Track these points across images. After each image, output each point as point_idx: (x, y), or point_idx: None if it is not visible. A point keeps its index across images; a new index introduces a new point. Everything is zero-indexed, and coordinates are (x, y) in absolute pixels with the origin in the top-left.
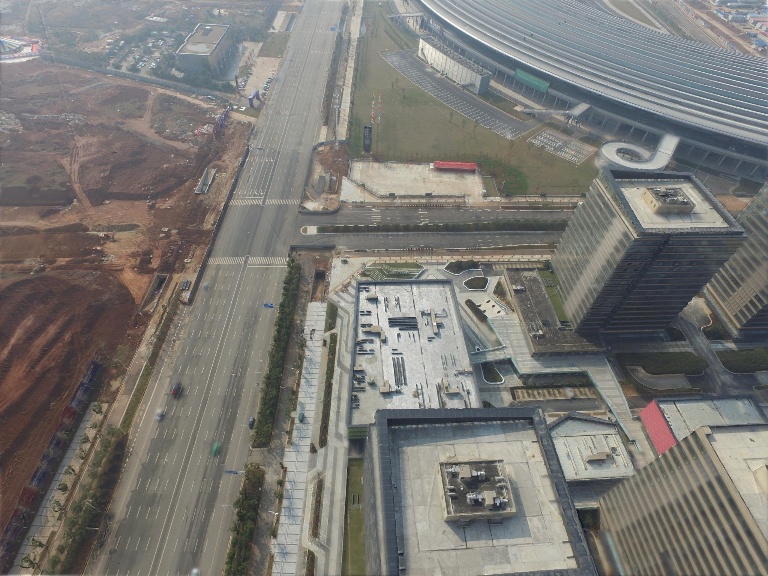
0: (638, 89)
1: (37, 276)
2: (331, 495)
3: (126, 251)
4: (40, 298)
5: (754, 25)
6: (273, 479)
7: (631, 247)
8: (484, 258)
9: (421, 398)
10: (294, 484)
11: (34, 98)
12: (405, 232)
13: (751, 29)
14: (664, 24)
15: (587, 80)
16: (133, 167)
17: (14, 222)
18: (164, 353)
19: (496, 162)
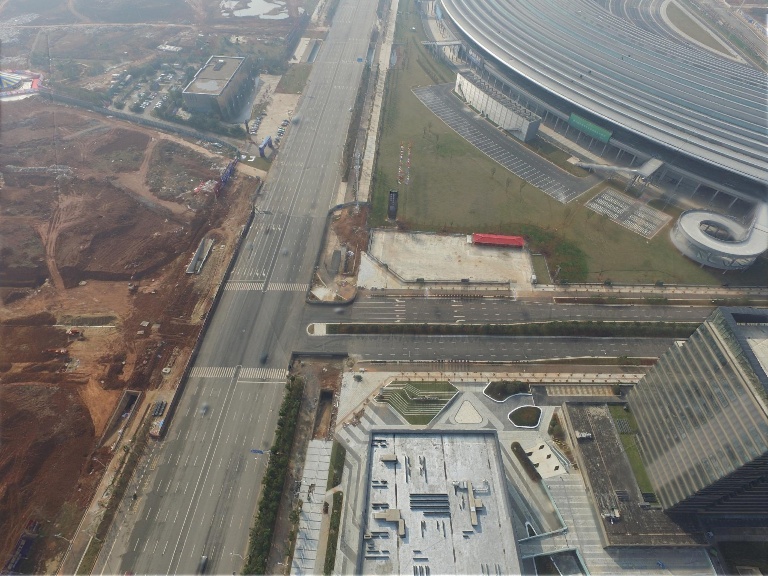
0: (725, 145)
1: None
2: None
3: (95, 354)
4: None
5: None
6: None
7: None
8: (535, 377)
9: None
10: None
11: (22, 146)
12: (435, 335)
13: None
14: (739, 51)
15: (660, 131)
16: (119, 236)
17: None
18: (120, 516)
19: (548, 234)
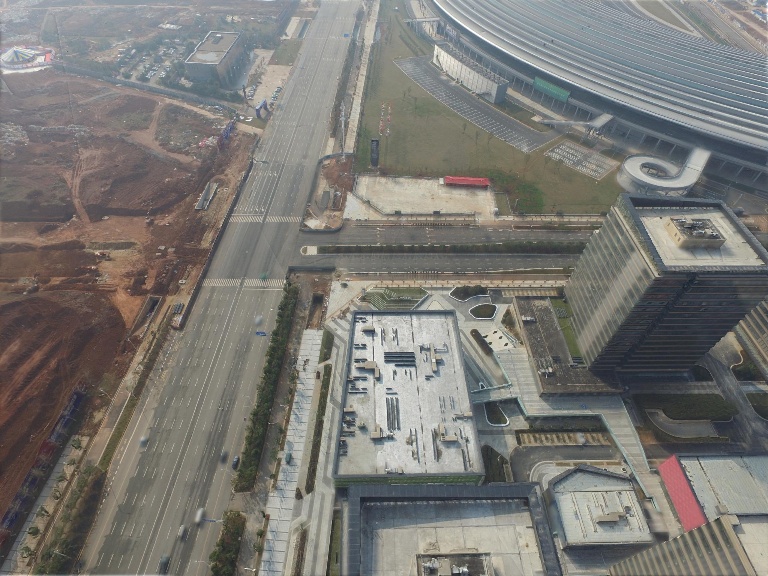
0: (666, 99)
1: (27, 298)
2: (315, 548)
3: (121, 271)
4: (28, 322)
5: None
6: (254, 528)
7: (651, 286)
8: (493, 283)
9: (415, 445)
10: (276, 534)
11: (42, 109)
12: (410, 253)
13: None
14: (696, 26)
15: (610, 89)
16: (135, 181)
17: (12, 238)
18: (151, 382)
19: (510, 177)
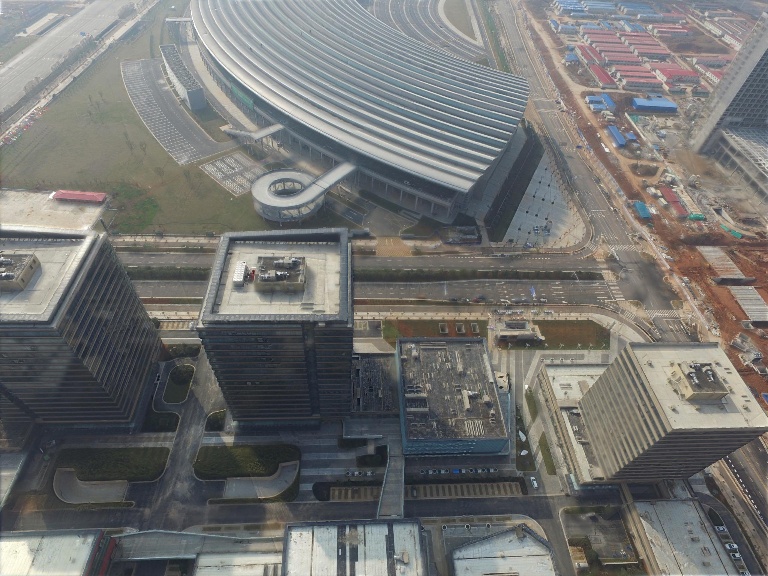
0: (327, 110)
1: None
2: None
3: None
4: None
5: (582, 37)
6: None
7: None
8: None
9: None
10: None
11: None
12: None
13: (576, 42)
14: (485, 34)
15: (282, 98)
16: None
17: None
18: None
19: (138, 192)
